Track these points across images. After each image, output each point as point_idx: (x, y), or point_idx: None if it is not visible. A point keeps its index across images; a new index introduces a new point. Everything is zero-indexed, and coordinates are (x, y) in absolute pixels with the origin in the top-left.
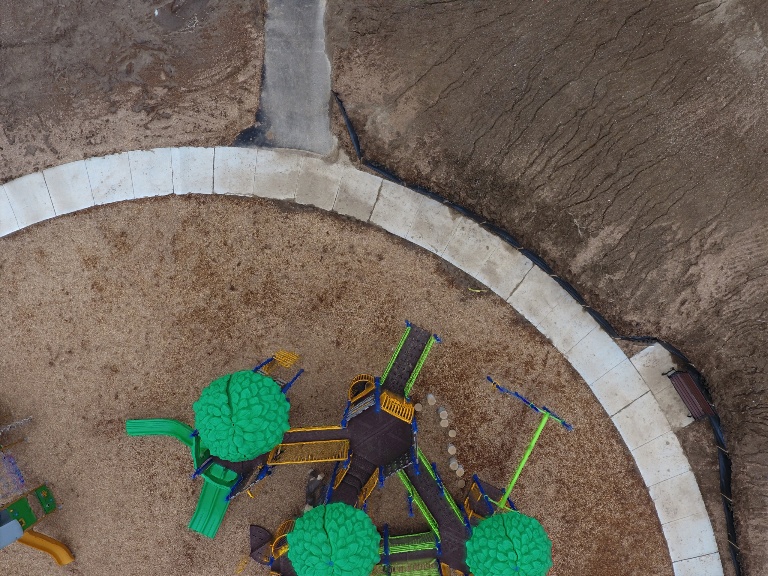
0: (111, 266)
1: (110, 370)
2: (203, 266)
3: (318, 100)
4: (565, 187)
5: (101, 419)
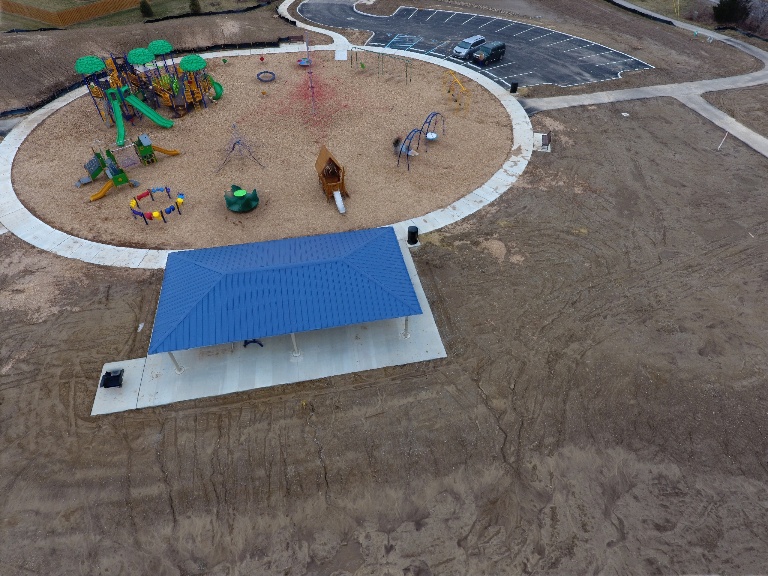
0: None
1: None
2: None
3: None
4: (61, 75)
5: None
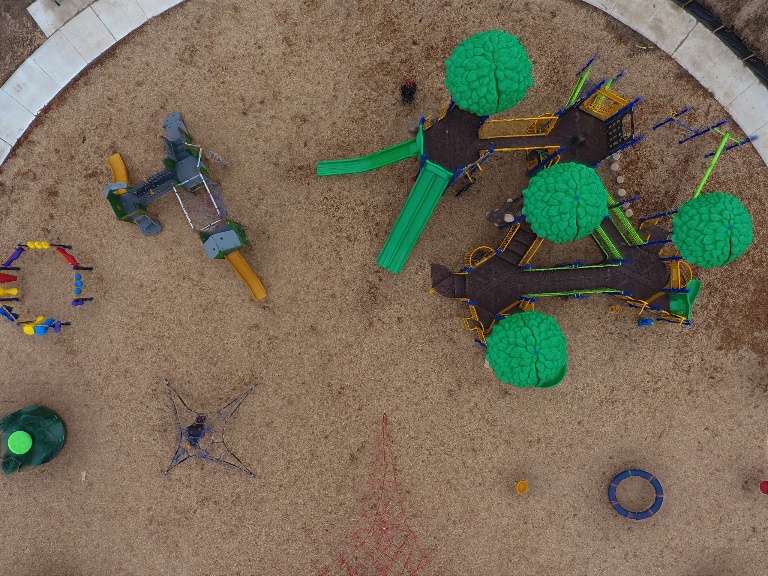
0: (300, 22)
1: (299, 120)
2: (386, 22)
3: None
4: None
5: (291, 165)
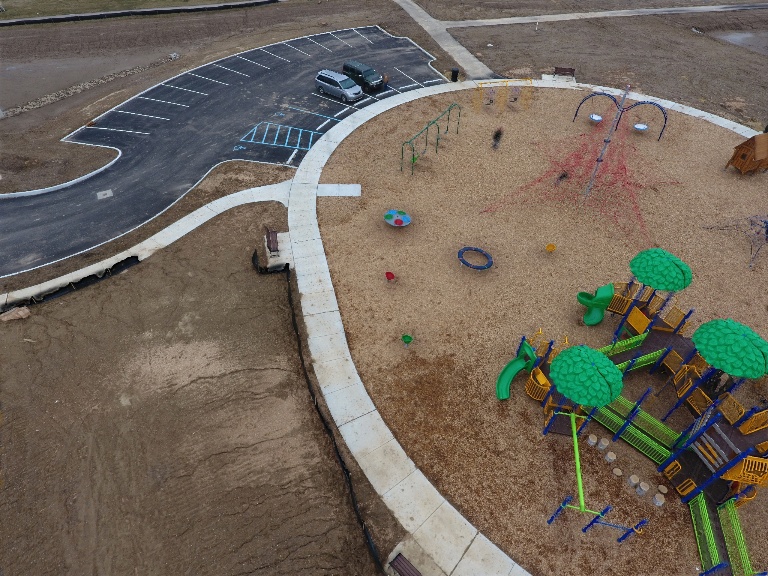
0: None
1: None
2: None
3: None
4: None
5: None
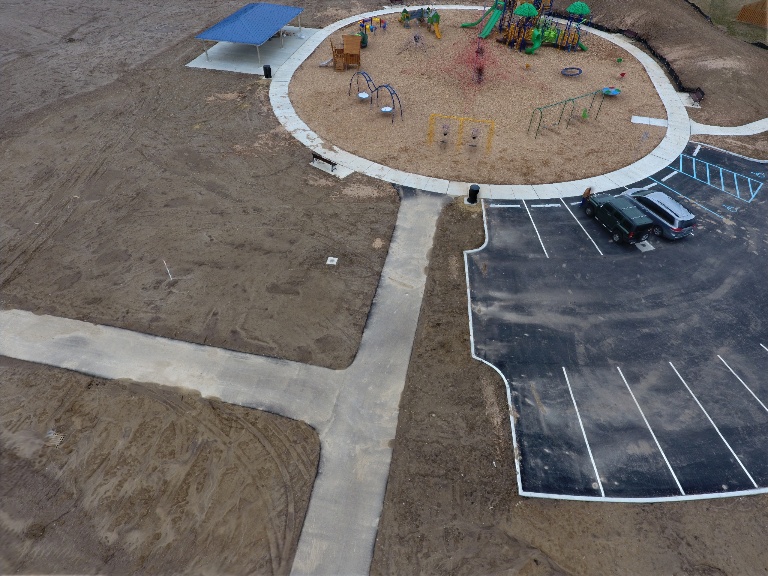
0: None
1: None
2: None
3: (517, 5)
4: None
5: None
